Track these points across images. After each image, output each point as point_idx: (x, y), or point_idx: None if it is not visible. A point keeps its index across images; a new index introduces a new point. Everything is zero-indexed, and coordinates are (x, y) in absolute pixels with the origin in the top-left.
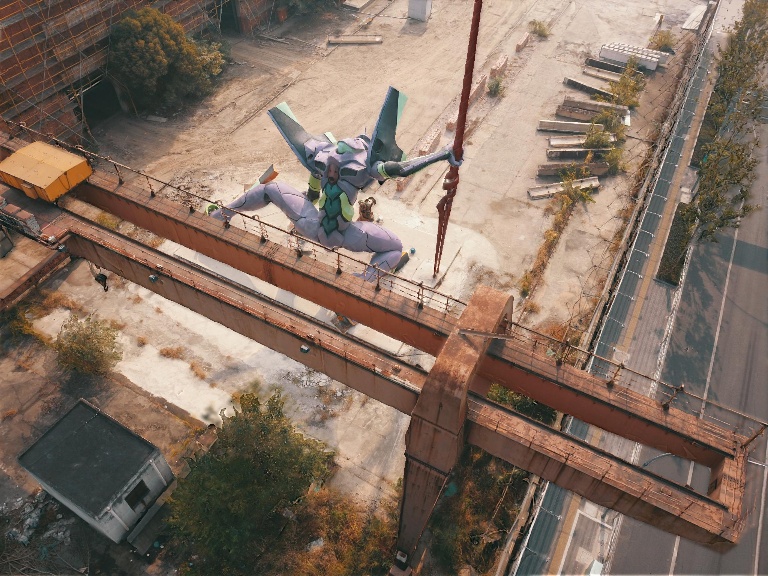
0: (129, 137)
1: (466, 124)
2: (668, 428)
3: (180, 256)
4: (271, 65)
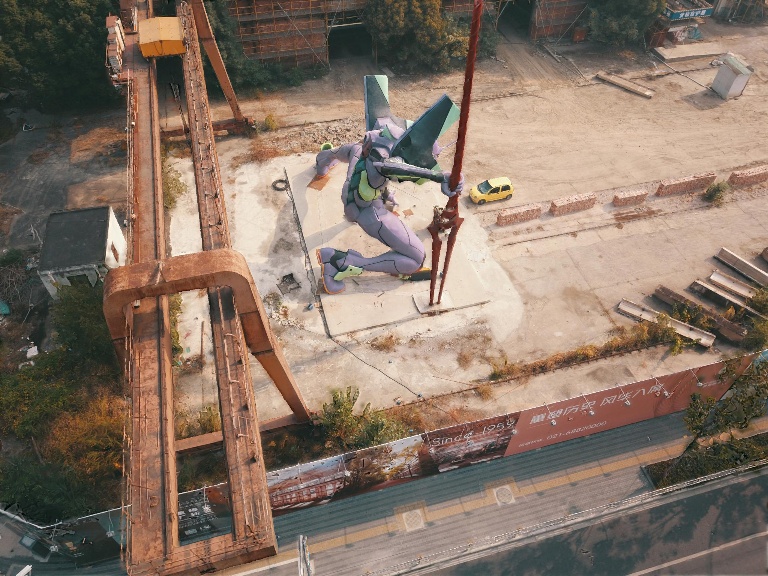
0: (356, 76)
1: (640, 208)
2: (228, 470)
3: (286, 170)
4: (522, 72)
